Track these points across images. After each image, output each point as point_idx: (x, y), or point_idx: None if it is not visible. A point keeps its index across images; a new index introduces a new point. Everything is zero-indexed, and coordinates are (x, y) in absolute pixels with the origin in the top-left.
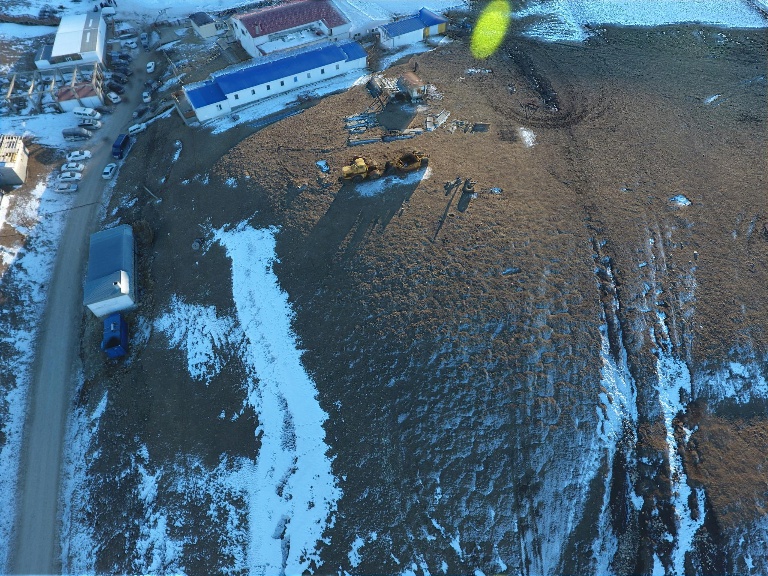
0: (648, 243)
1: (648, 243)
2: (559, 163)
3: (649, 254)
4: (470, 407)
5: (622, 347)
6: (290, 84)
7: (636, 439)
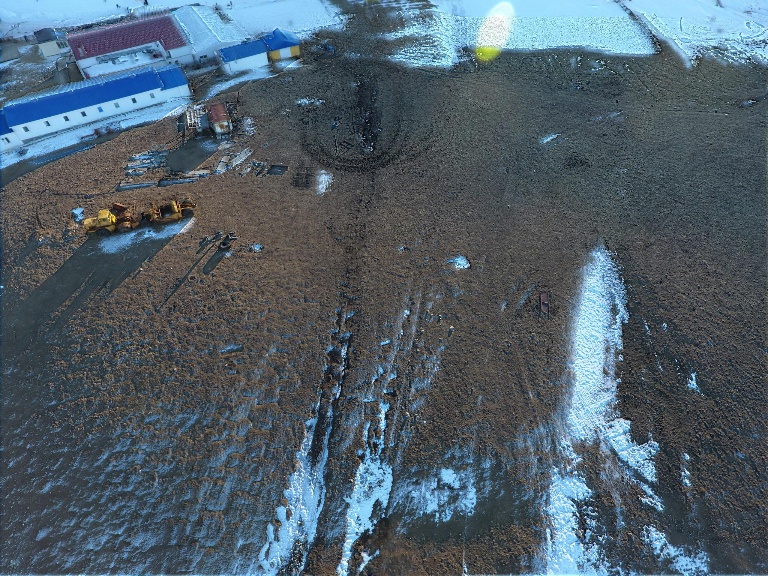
0: (401, 315)
1: (401, 315)
2: (342, 215)
3: (397, 329)
4: (122, 522)
5: (325, 447)
6: (95, 114)
7: (302, 567)
